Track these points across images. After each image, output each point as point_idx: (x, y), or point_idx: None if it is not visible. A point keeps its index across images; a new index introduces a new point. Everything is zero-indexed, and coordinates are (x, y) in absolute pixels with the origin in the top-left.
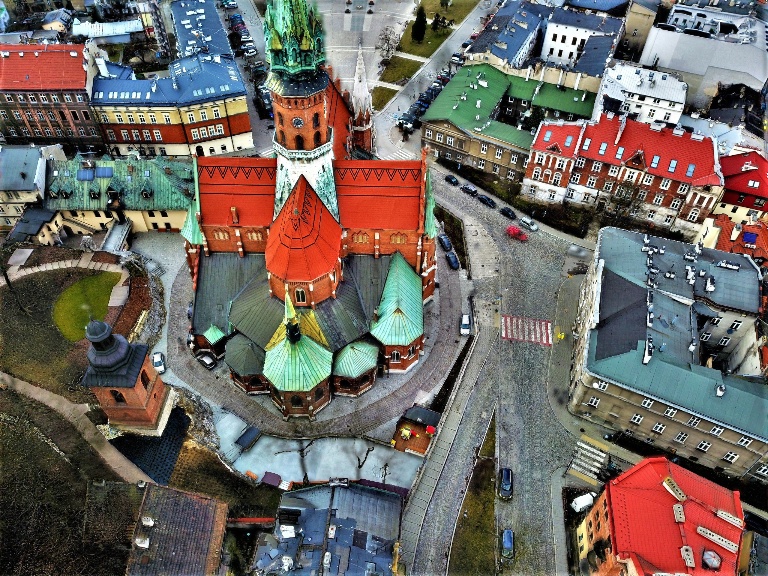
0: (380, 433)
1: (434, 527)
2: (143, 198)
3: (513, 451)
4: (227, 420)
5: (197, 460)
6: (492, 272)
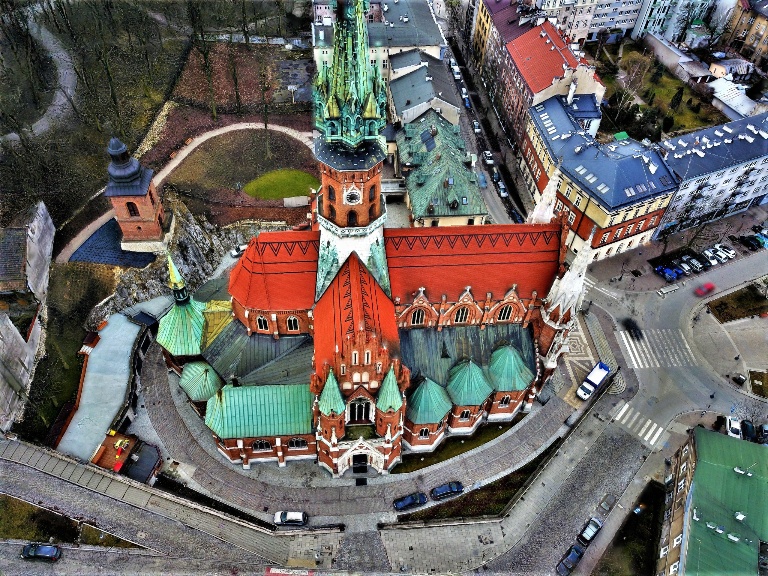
0: (147, 431)
1: (6, 472)
2: (417, 182)
3: (84, 567)
4: (166, 302)
5: (102, 278)
6: (399, 561)
